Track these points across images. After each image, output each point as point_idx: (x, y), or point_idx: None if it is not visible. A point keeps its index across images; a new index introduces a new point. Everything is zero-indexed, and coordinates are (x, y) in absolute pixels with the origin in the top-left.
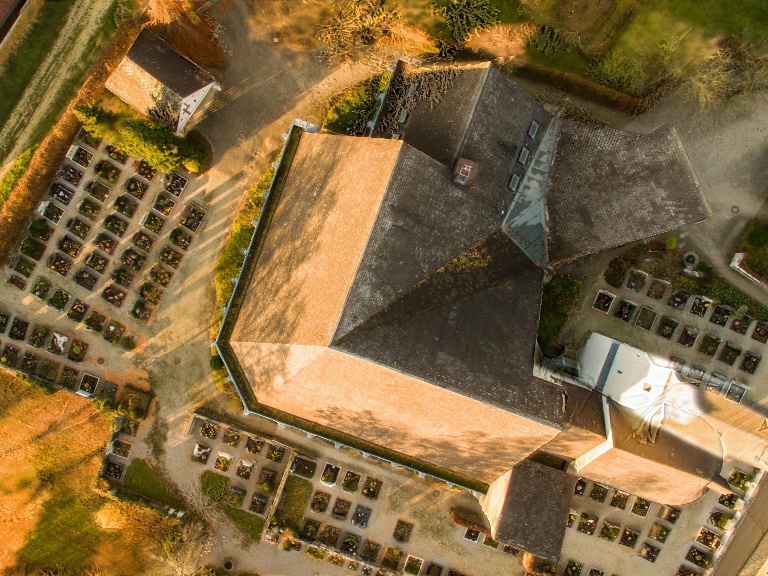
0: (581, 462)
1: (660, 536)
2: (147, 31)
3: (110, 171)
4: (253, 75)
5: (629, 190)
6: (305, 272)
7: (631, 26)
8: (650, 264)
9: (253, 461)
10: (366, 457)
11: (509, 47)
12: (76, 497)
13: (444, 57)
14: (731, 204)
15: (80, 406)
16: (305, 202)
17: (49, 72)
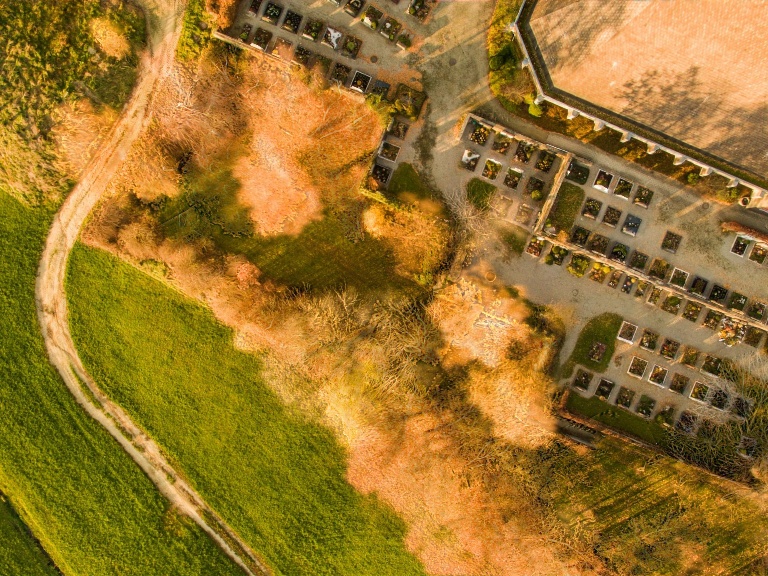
0: None
1: None
2: None
3: None
4: None
5: None
6: None
7: None
8: None
9: (521, 170)
10: (639, 166)
11: None
12: (330, 209)
13: None
14: None
15: (342, 113)
16: None
17: None
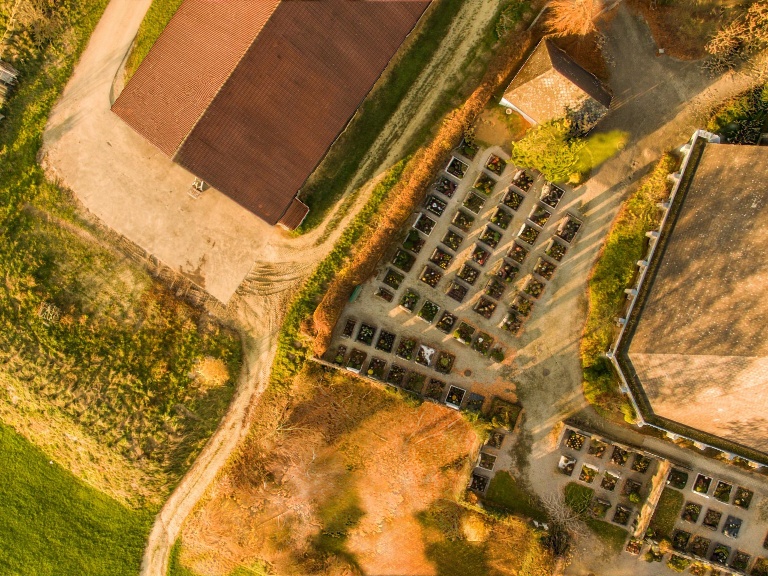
0: None
1: None
2: (549, 42)
3: (486, 182)
4: (634, 86)
5: None
6: (762, 284)
7: None
8: None
9: (617, 472)
10: (738, 467)
11: None
12: (427, 510)
13: None
14: None
15: (436, 418)
16: (737, 214)
17: (426, 83)
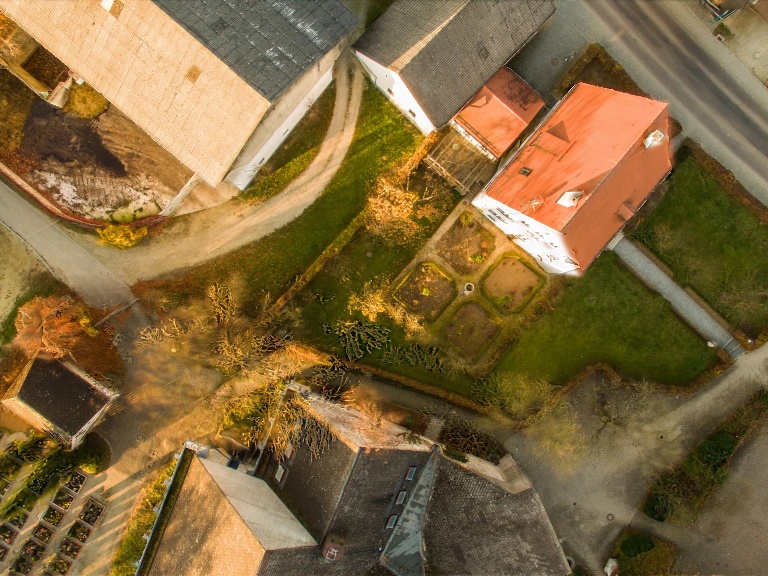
0: None
1: None
2: (43, 353)
3: (10, 466)
4: (151, 381)
5: (498, 538)
6: None
7: (515, 349)
8: None
9: None
10: None
11: (399, 364)
12: None
13: (336, 372)
14: (607, 512)
15: None
16: (189, 543)
17: None
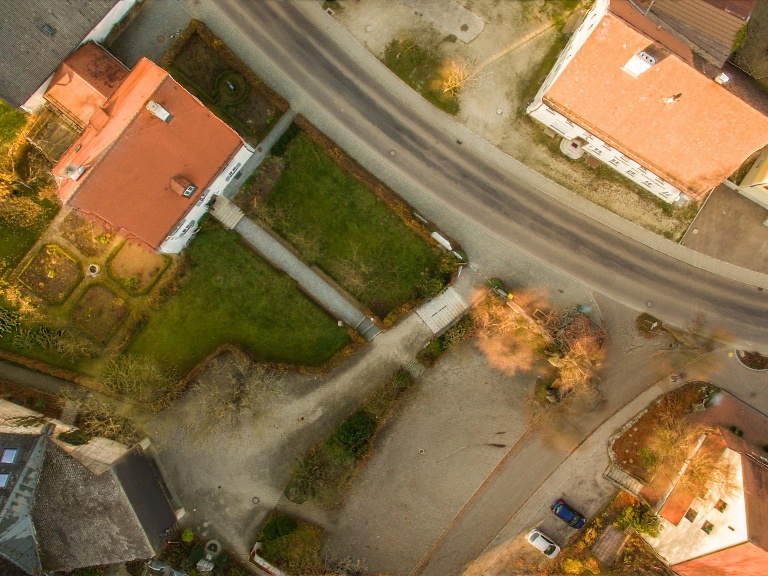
0: None
1: None
2: None
3: None
4: None
5: (91, 521)
6: None
7: (145, 331)
8: (167, 556)
9: None
10: None
11: (30, 348)
12: None
13: None
14: (252, 495)
15: None
16: None
17: None
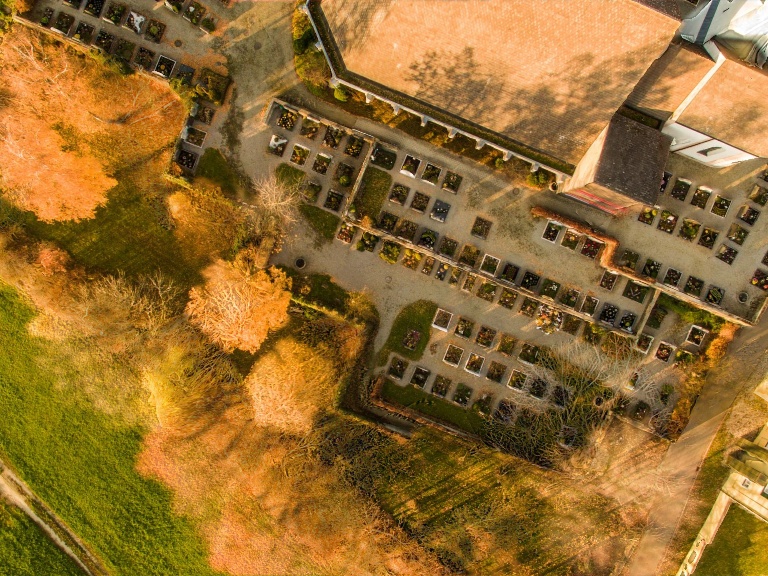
0: (682, 107)
1: (738, 238)
2: None
3: None
4: None
5: None
6: None
7: None
8: None
9: (330, 156)
10: (447, 150)
11: None
12: (142, 196)
13: None
14: None
15: (152, 98)
16: None
17: None
